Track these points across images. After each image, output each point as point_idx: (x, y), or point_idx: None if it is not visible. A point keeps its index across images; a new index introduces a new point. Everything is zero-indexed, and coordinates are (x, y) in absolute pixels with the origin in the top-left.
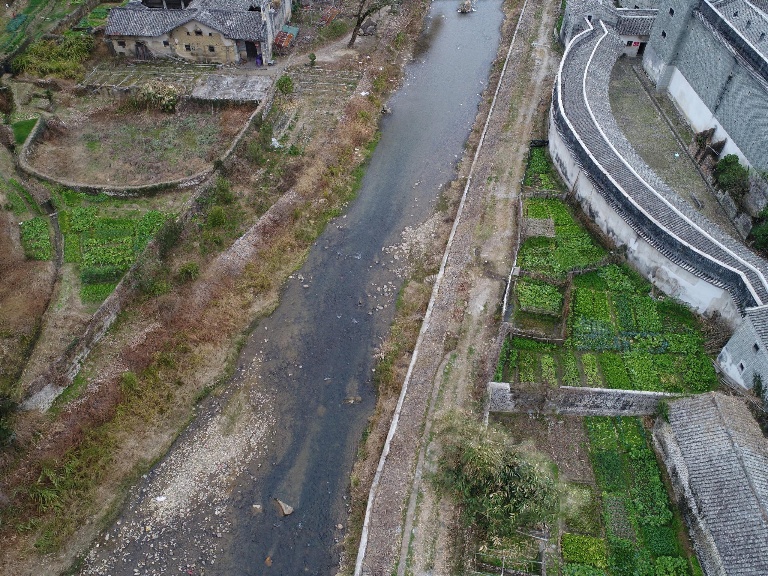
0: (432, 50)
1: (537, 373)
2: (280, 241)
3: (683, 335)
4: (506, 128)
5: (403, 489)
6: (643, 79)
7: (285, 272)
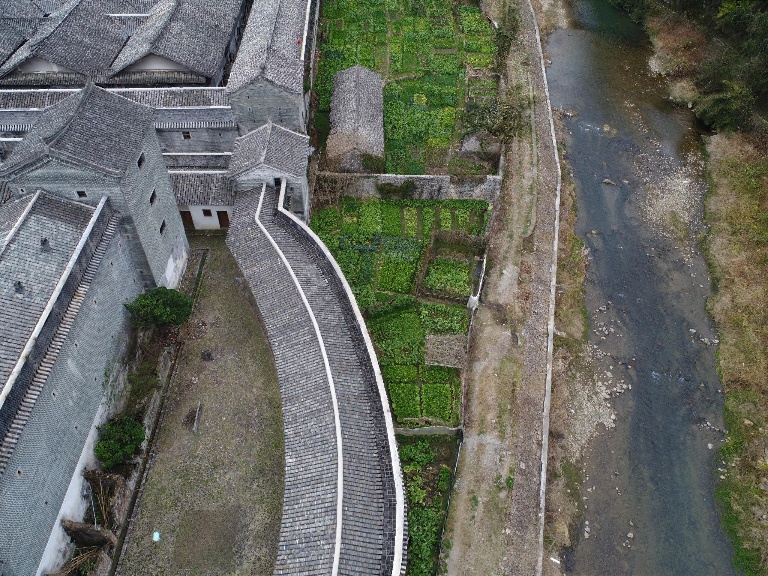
0: None
1: (455, 225)
2: (762, 371)
3: None
4: None
5: (542, 168)
6: None
7: (727, 343)
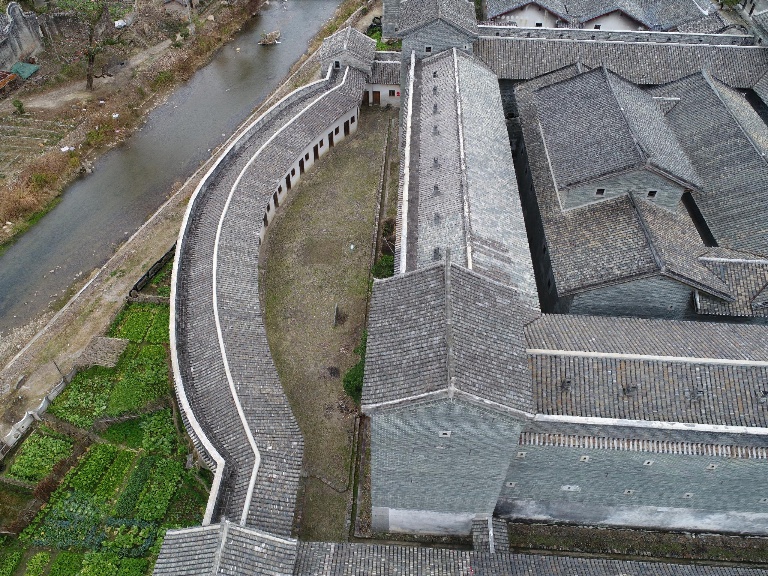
0: (196, 92)
1: None
2: None
3: (187, 526)
4: (186, 201)
5: None
6: (393, 137)
7: None
